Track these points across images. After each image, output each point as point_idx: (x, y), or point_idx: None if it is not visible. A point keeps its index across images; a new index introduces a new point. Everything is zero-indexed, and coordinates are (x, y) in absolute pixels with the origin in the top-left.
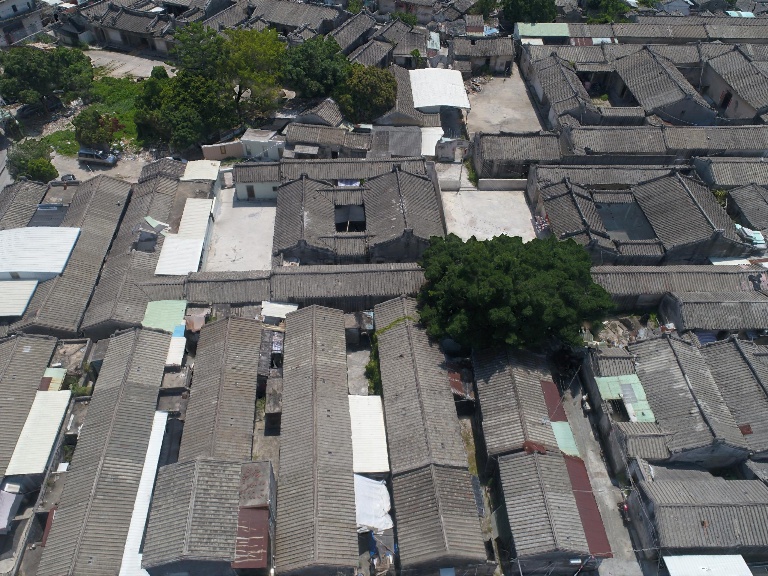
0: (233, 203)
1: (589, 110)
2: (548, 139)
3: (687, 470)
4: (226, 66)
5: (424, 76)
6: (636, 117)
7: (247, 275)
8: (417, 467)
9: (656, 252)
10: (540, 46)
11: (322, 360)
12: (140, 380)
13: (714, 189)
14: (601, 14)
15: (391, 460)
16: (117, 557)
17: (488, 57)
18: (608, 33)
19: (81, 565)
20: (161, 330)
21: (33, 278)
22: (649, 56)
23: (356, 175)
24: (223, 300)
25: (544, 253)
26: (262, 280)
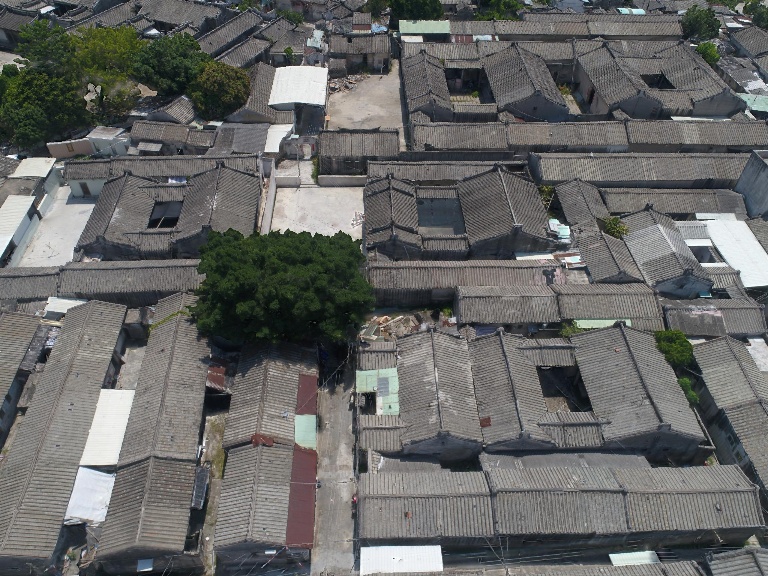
0: (67, 200)
1: (440, 107)
2: (388, 135)
3: (420, 462)
4: (73, 64)
5: (288, 73)
6: (489, 113)
7: (40, 271)
8: (138, 460)
9: (461, 247)
10: (415, 43)
11: (83, 354)
12: None
13: (540, 185)
14: (489, 11)
15: (119, 453)
16: None
17: (364, 55)
18: (489, 30)
19: None
20: None
21: None
22: (515, 53)
23: (187, 172)
24: (10, 296)
25: (303, 247)
26: (52, 276)
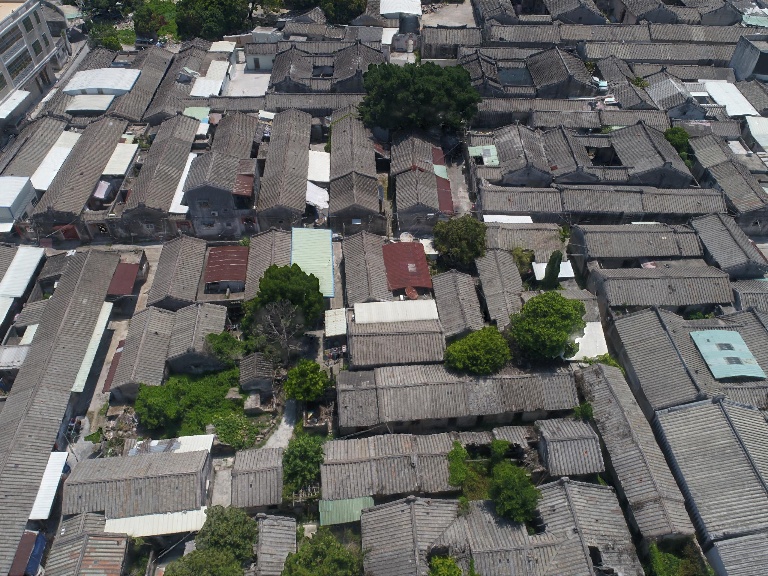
0: (244, 71)
1: (509, 16)
2: (473, 31)
3: None
4: None
5: None
6: (545, 22)
7: None
8: (345, 174)
9: (531, 91)
10: None
11: (294, 132)
12: (181, 137)
13: (586, 61)
14: None
15: (330, 174)
16: (168, 203)
17: None
18: None
19: (149, 201)
20: (194, 117)
21: (111, 94)
22: None
23: (331, 50)
24: (234, 108)
25: (436, 66)
26: (260, 98)
